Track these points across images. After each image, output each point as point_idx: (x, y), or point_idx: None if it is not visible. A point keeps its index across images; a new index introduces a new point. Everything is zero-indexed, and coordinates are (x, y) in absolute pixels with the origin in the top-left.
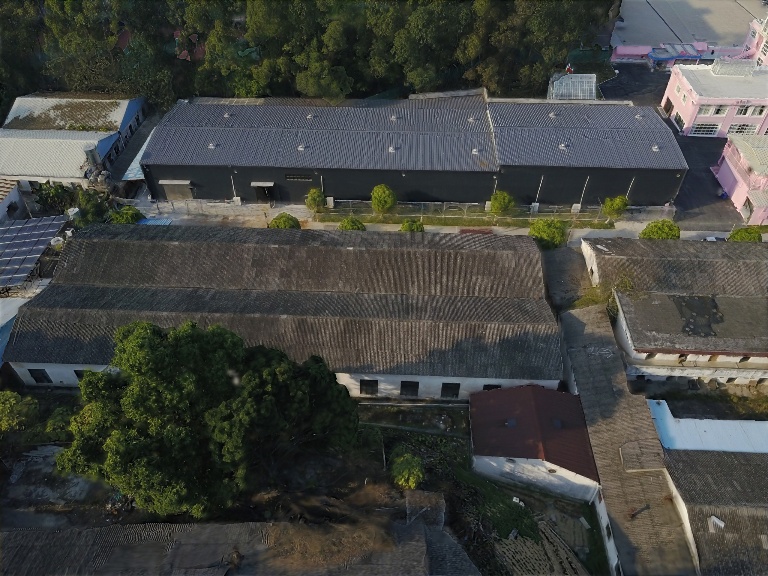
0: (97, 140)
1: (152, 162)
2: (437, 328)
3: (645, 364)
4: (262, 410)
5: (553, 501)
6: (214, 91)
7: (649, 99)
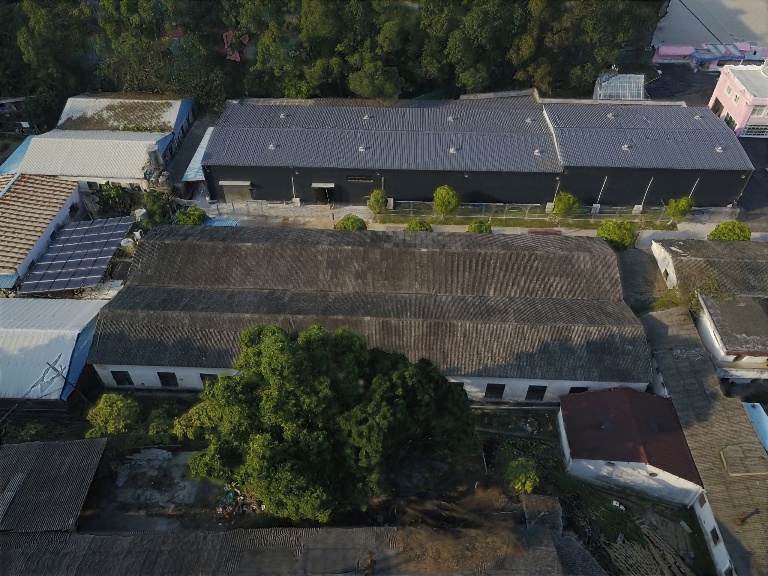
0: (155, 141)
1: (214, 163)
2: (522, 330)
3: (734, 367)
4: (398, 414)
5: (651, 505)
6: (262, 92)
7: (696, 100)
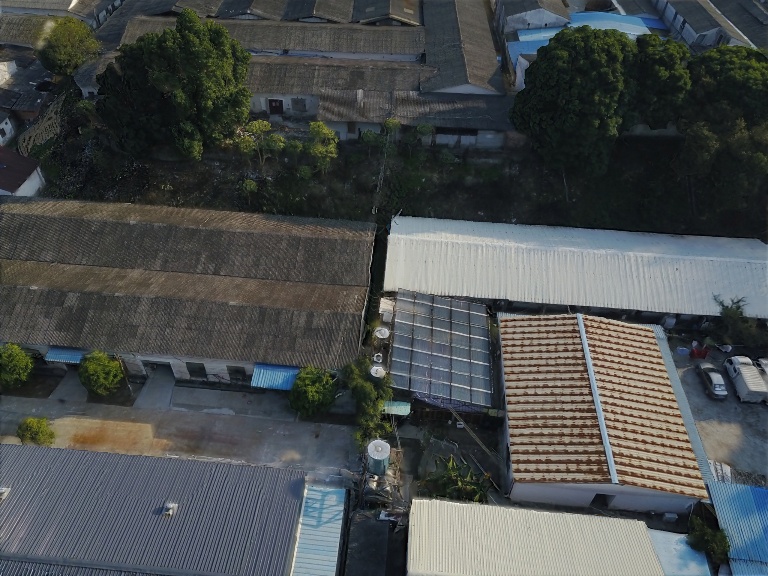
0: (411, 575)
1: (281, 471)
2: None
3: None
4: None
5: None
6: None
7: None
